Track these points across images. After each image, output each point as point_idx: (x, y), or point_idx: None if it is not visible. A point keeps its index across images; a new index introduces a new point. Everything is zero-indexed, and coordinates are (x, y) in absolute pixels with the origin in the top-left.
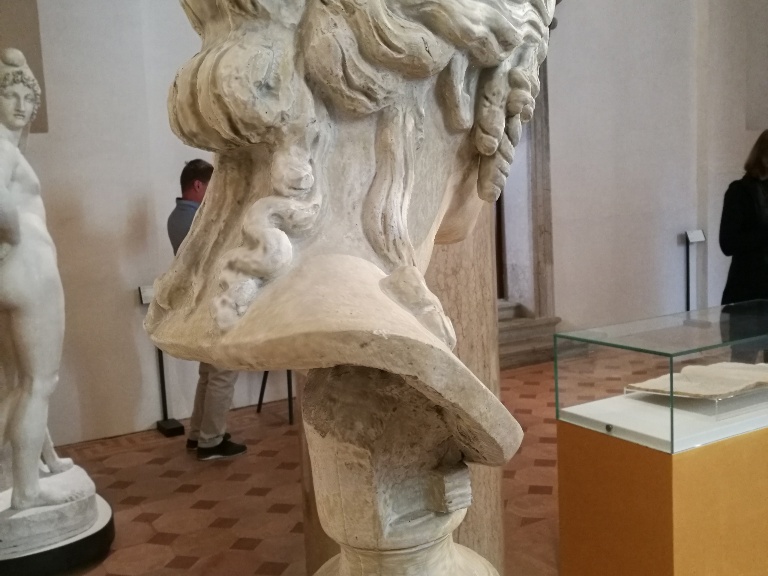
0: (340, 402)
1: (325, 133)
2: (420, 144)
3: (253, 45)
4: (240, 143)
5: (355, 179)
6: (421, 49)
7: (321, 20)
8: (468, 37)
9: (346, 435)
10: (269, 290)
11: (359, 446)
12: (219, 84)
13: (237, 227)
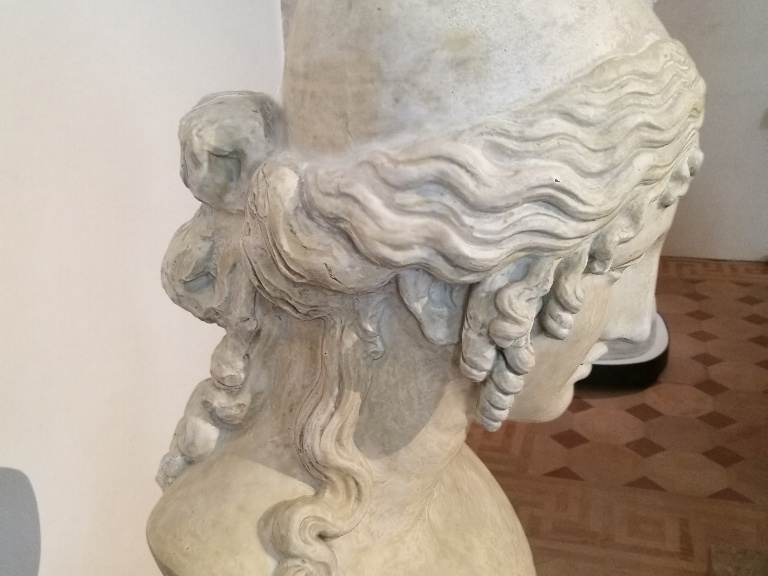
0: None
1: (270, 327)
2: (375, 356)
3: (192, 235)
4: None
5: (298, 380)
6: (325, 276)
7: (244, 219)
8: None
9: None
10: (188, 473)
11: None
12: None
13: None
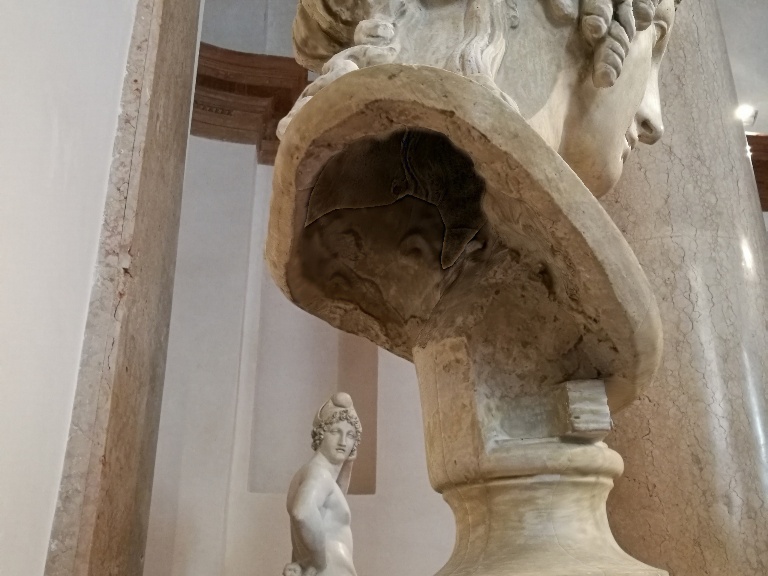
0: (445, 310)
1: (413, 11)
2: (514, 22)
3: None
4: (339, 34)
5: (441, 44)
6: None
7: None
8: None
9: (445, 334)
10: None
11: (455, 336)
12: None
13: None
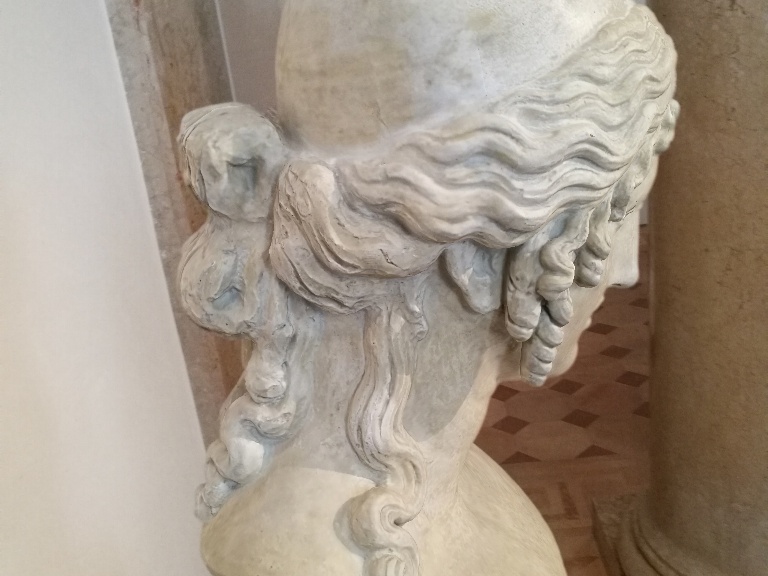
0: None
1: (305, 330)
2: (421, 337)
3: (212, 251)
4: None
5: (341, 377)
6: (381, 262)
7: (276, 224)
8: (448, 238)
9: None
10: (236, 498)
11: None
12: None
13: None
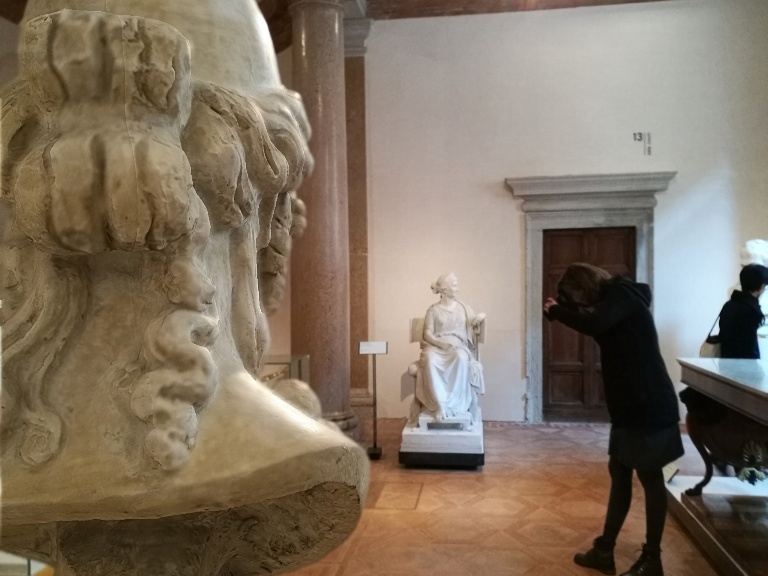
0: (138, 546)
1: None
2: None
3: (171, 143)
4: (128, 248)
5: (222, 293)
6: (285, 172)
7: (218, 128)
8: (300, 166)
9: None
10: (210, 416)
11: None
12: (154, 182)
13: (83, 346)
